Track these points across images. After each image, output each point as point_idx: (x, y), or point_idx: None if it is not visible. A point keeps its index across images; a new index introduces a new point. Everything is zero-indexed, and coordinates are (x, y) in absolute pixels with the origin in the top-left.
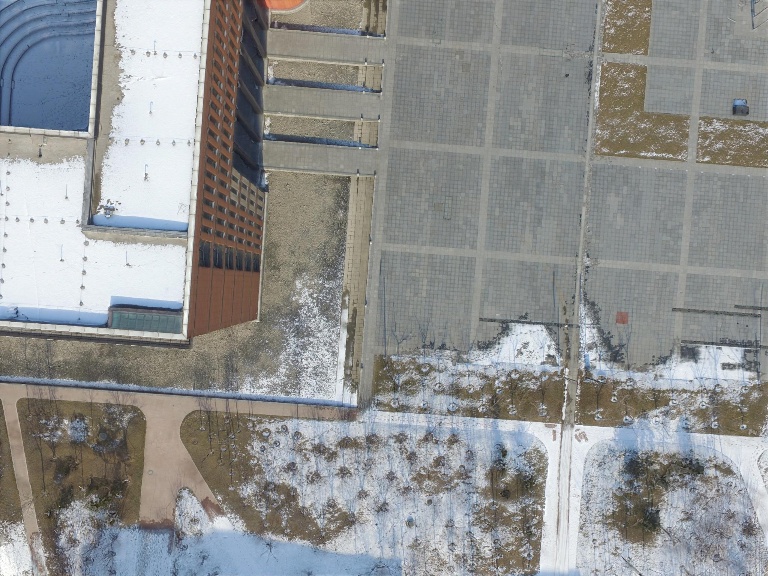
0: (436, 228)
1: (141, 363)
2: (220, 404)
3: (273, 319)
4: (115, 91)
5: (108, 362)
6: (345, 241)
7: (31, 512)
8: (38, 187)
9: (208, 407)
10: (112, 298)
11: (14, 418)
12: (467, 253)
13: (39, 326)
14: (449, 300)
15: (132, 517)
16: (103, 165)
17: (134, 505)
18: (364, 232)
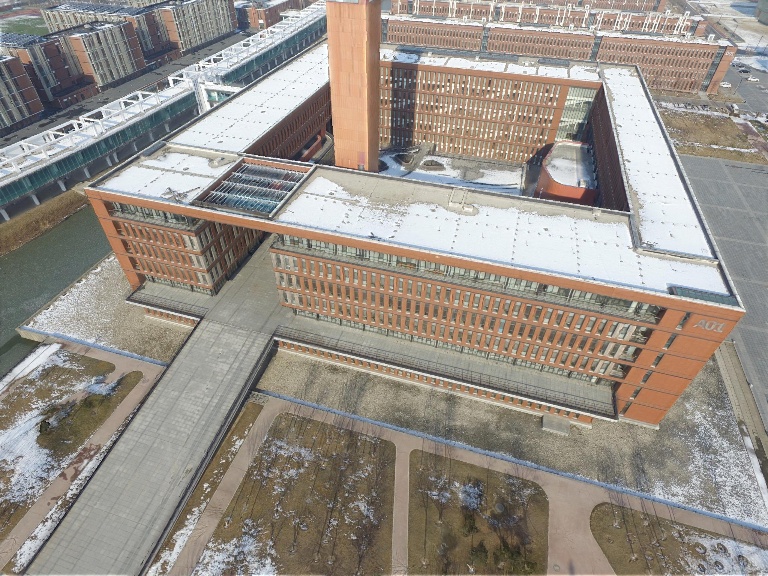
0: None
1: (539, 443)
2: (634, 501)
3: (671, 431)
4: (637, 204)
5: (505, 436)
6: (723, 382)
7: None
8: (596, 230)
9: (620, 502)
10: (667, 284)
11: (405, 467)
12: None
13: (618, 286)
14: None
15: None
16: (639, 227)
17: None
18: (739, 378)
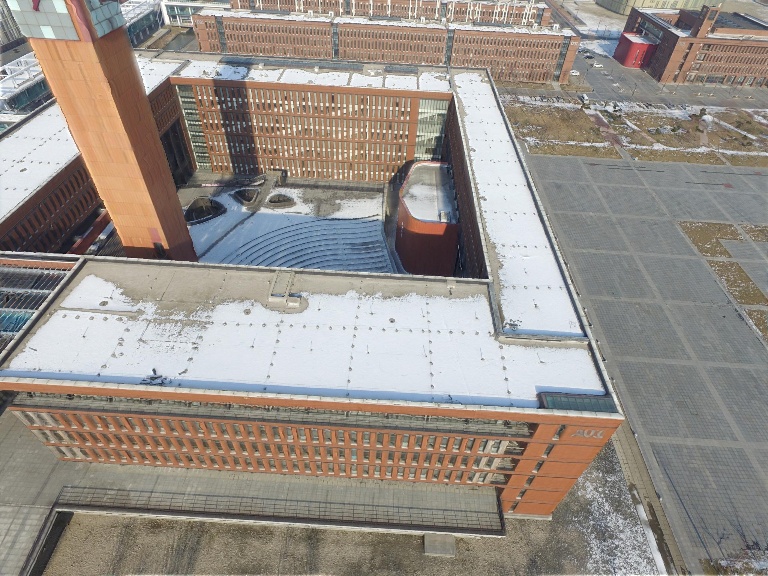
0: (689, 422)
1: None
2: None
3: (564, 517)
4: (497, 263)
5: None
6: None
7: None
8: (452, 312)
9: None
10: (536, 387)
11: None
12: (732, 444)
13: (479, 407)
14: (743, 492)
15: None
16: (501, 299)
17: None
18: (624, 426)
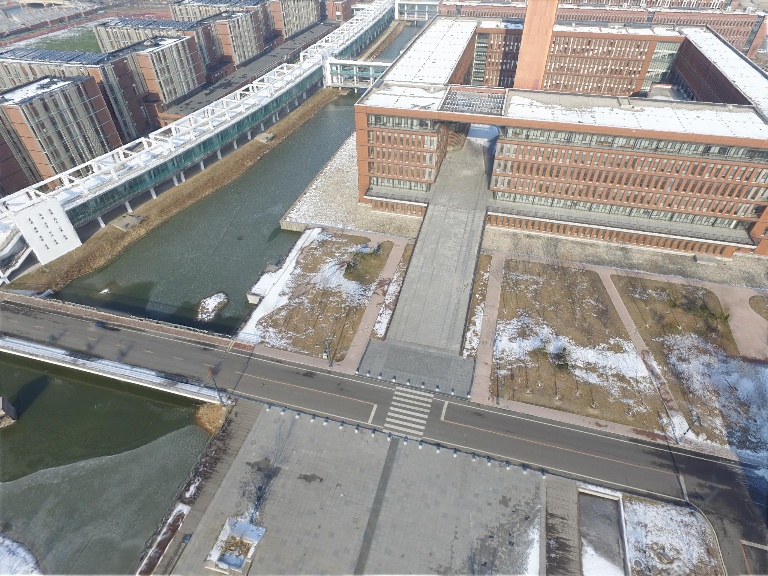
0: None
1: (697, 270)
2: None
3: None
4: None
5: (671, 267)
6: None
7: (637, 336)
8: (734, 116)
9: (766, 295)
10: None
11: (609, 283)
12: None
13: None
14: None
15: (733, 352)
16: None
17: (731, 344)
18: None
